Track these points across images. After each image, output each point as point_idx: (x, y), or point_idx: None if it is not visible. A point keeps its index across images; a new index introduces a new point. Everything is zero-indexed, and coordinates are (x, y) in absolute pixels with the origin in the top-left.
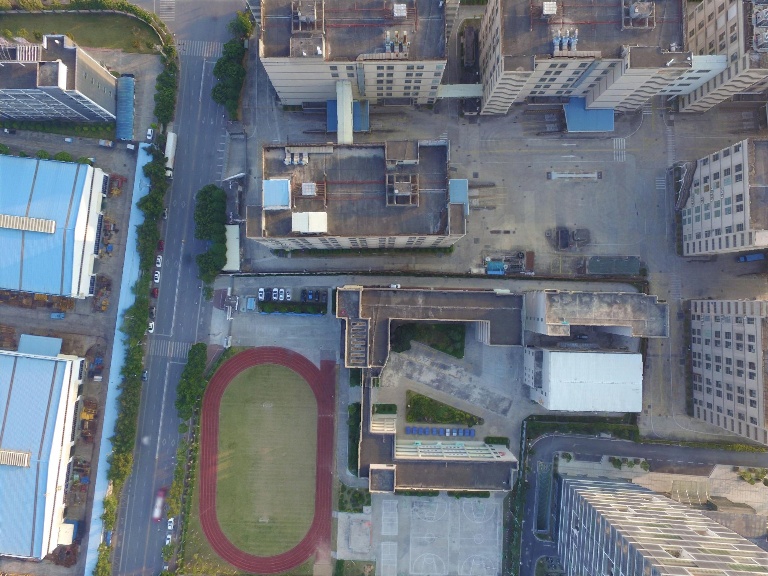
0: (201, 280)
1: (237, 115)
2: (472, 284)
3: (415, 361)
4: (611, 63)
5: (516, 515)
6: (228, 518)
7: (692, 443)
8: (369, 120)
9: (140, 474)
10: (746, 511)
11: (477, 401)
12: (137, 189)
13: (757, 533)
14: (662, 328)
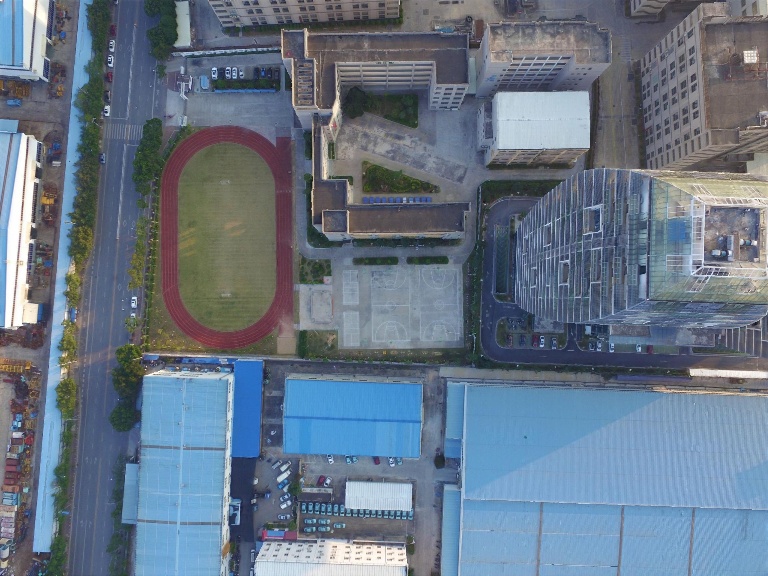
0: (154, 63)
1: None
2: None
3: (369, 133)
4: None
5: (475, 277)
6: (191, 295)
7: None
8: None
9: (102, 255)
10: None
11: (432, 170)
12: None
13: None
14: (605, 56)
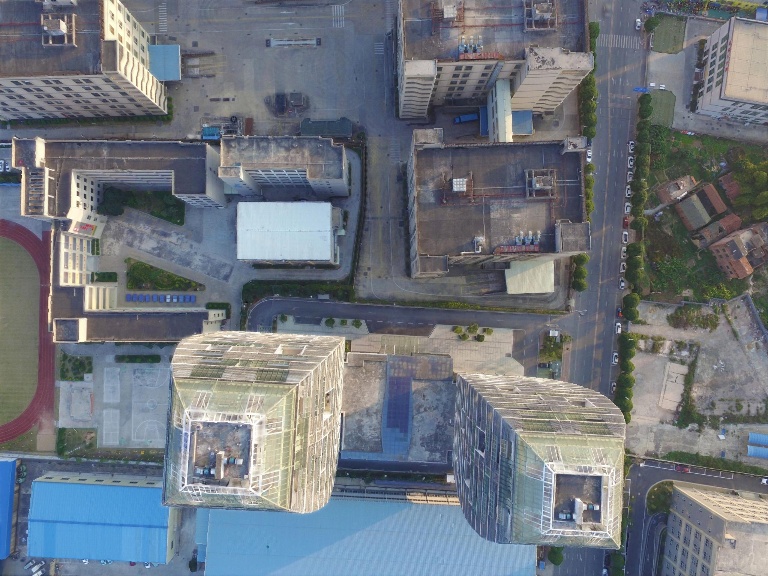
0: None
1: None
2: None
3: (135, 229)
4: None
5: None
6: None
7: (407, 302)
8: None
9: None
10: (440, 357)
11: (198, 268)
12: None
13: (443, 375)
14: (339, 171)
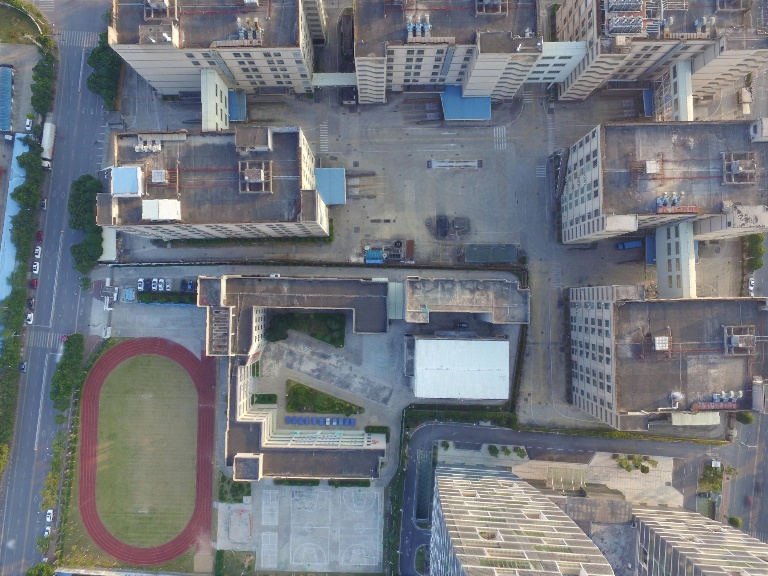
0: None
1: (115, 105)
2: (352, 273)
3: (295, 351)
4: (467, 49)
5: (395, 504)
6: (108, 509)
7: (570, 430)
8: (249, 110)
9: (19, 466)
10: (615, 497)
11: (358, 390)
12: (13, 180)
13: (622, 519)
14: (524, 314)
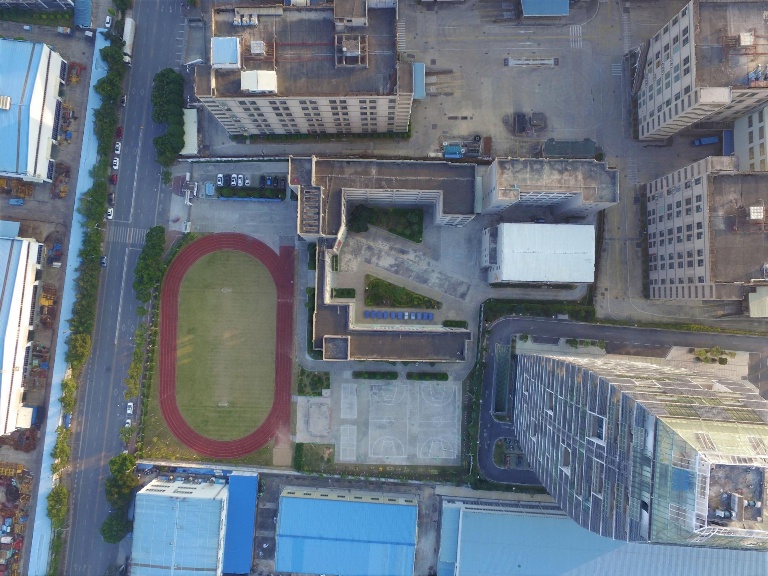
0: (160, 167)
1: (195, 1)
2: None
3: (373, 246)
4: None
5: (474, 396)
6: (188, 403)
7: (648, 323)
8: None
9: (99, 359)
10: None
11: (435, 285)
12: (95, 74)
13: None
14: (612, 195)
